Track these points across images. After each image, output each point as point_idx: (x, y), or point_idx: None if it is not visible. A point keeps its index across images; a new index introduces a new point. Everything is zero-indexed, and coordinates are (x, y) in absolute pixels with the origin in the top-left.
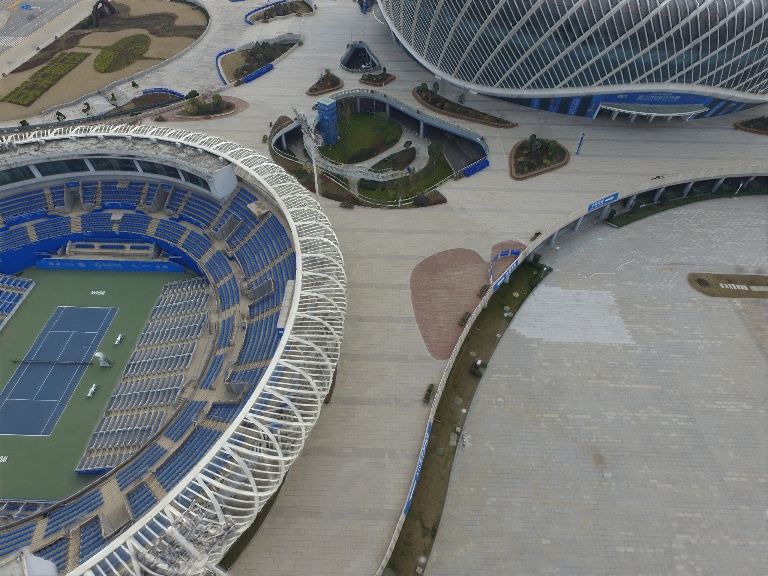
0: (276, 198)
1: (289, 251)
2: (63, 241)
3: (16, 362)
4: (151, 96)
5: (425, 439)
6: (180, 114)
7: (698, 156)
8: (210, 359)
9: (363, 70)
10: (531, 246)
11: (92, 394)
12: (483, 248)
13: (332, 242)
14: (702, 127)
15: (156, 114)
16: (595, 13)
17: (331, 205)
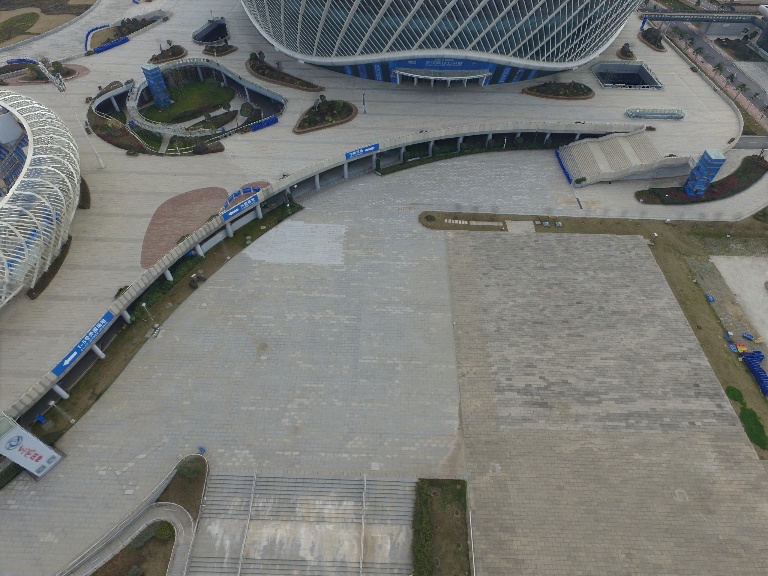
0: (29, 138)
1: None
2: None
3: None
4: (14, 66)
5: (97, 323)
6: (22, 79)
7: (472, 115)
8: None
9: (209, 42)
10: (275, 185)
11: None
12: (234, 187)
13: (59, 171)
14: (493, 91)
15: (1, 79)
16: None
17: (119, 153)
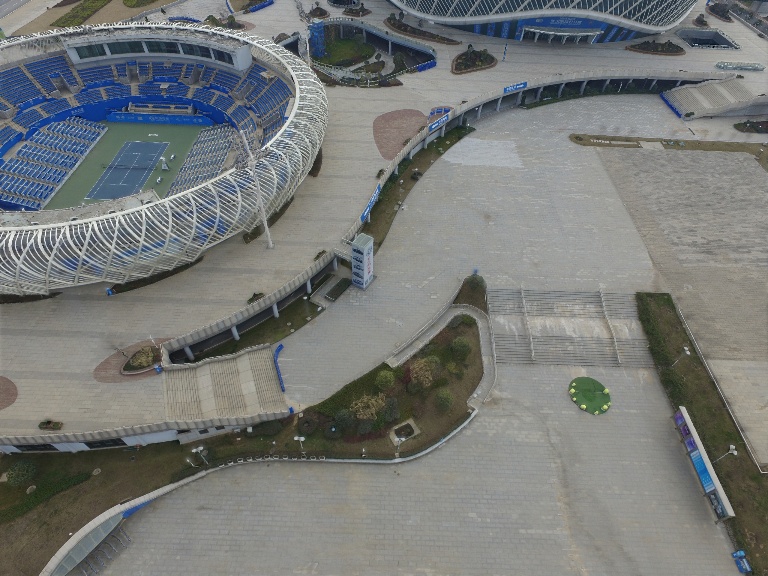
0: (281, 61)
1: (290, 96)
2: (126, 102)
3: (104, 167)
4: None
5: (376, 191)
6: None
7: (592, 64)
8: None
9: (346, 6)
10: (459, 108)
11: (159, 182)
12: (425, 109)
13: (319, 83)
14: (601, 48)
15: None
16: None
17: None
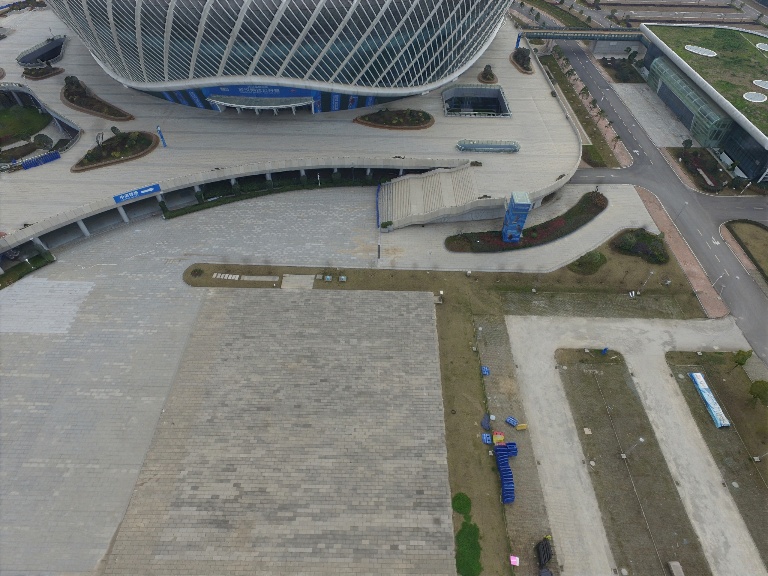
0: None
1: None
2: None
3: None
4: None
5: None
6: None
7: (285, 148)
8: None
9: (33, 64)
10: (9, 237)
11: None
12: None
13: None
14: (322, 120)
15: None
16: (127, 5)
17: None
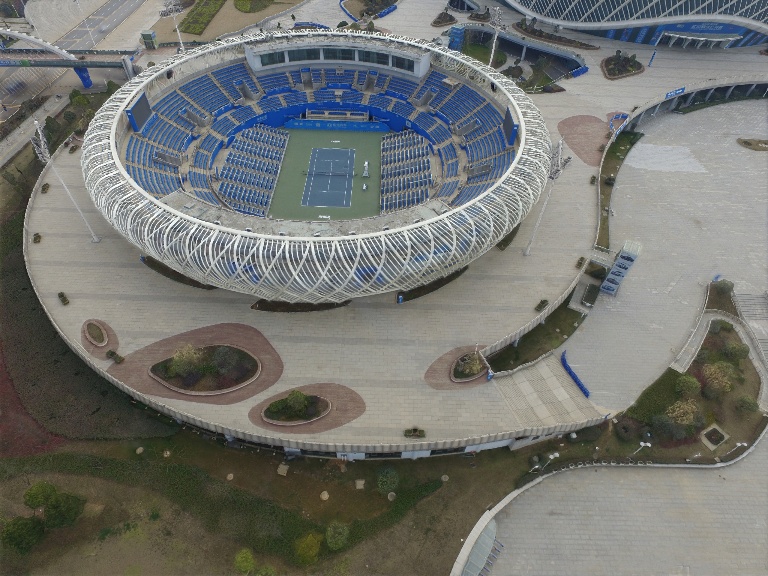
0: (475, 68)
1: (484, 103)
2: (303, 109)
3: (304, 174)
4: None
5: None
6: None
7: (736, 69)
8: (445, 165)
9: (469, 11)
10: (633, 114)
11: (366, 188)
12: (600, 115)
13: None
14: (736, 53)
15: None
16: None
17: None
